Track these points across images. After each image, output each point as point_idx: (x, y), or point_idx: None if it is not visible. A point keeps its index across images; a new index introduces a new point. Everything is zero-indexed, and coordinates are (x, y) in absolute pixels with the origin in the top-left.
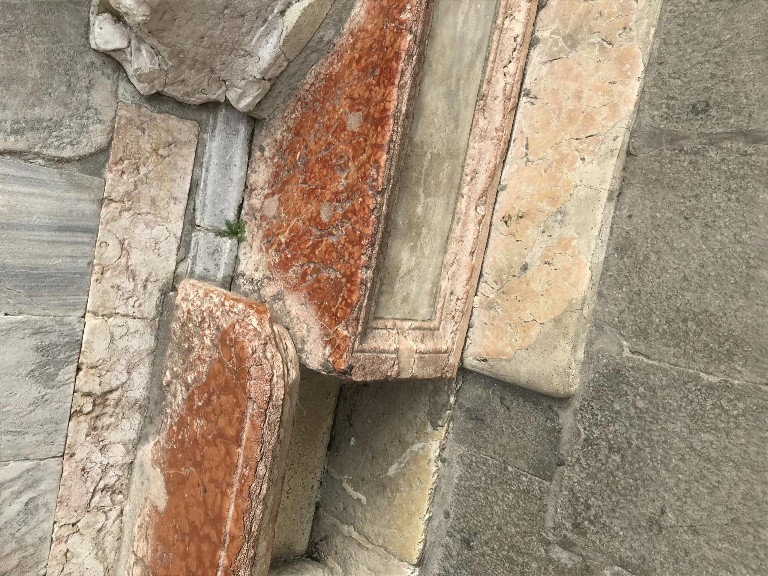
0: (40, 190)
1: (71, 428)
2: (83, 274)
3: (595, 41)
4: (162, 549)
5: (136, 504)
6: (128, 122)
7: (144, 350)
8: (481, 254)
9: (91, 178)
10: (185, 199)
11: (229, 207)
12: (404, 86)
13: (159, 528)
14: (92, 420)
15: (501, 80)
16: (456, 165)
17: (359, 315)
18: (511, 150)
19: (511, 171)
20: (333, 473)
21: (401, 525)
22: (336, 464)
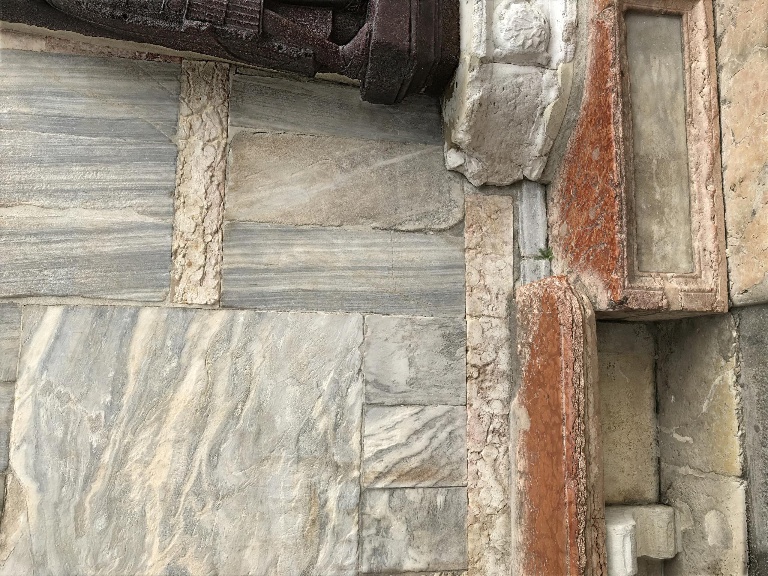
0: (433, 248)
1: (468, 387)
2: (461, 292)
3: (757, 50)
4: (533, 454)
5: (515, 439)
6: (472, 204)
7: (503, 338)
8: (721, 218)
9: (457, 238)
10: (512, 242)
11: (540, 241)
12: (617, 122)
13: (529, 442)
14: (479, 383)
15: (700, 101)
16: (681, 164)
17: (623, 264)
18: (724, 142)
19: (727, 155)
20: (665, 430)
21: (722, 447)
22: (665, 421)
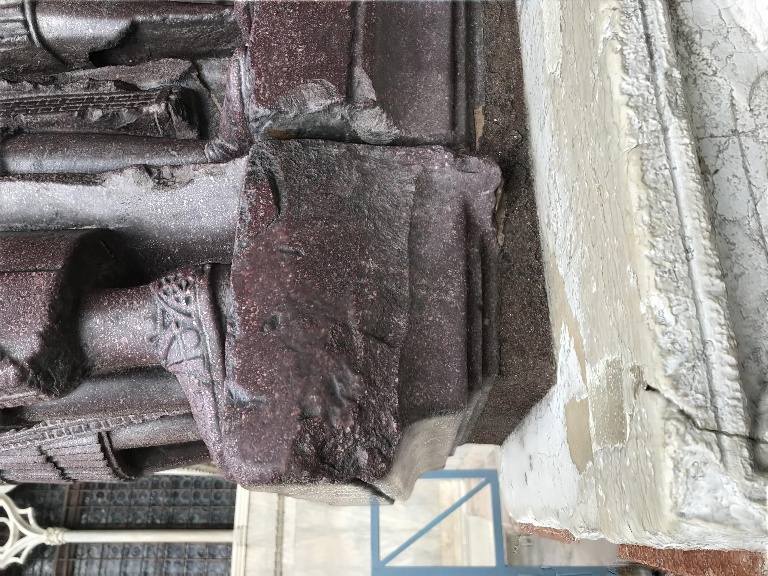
0: None
1: None
2: None
3: None
4: None
5: None
6: None
7: None
8: None
9: None
10: None
11: None
12: None
13: None
14: None
15: None
16: None
17: None
18: None
19: None
20: None
21: None
22: None
